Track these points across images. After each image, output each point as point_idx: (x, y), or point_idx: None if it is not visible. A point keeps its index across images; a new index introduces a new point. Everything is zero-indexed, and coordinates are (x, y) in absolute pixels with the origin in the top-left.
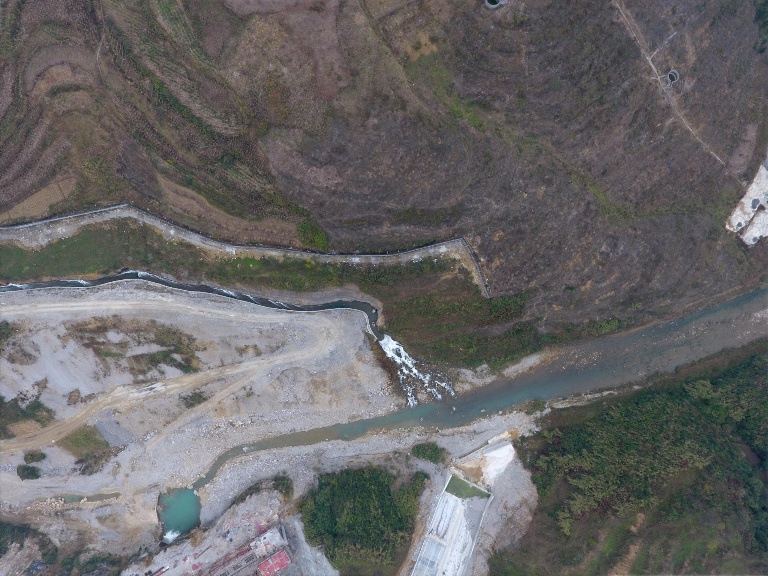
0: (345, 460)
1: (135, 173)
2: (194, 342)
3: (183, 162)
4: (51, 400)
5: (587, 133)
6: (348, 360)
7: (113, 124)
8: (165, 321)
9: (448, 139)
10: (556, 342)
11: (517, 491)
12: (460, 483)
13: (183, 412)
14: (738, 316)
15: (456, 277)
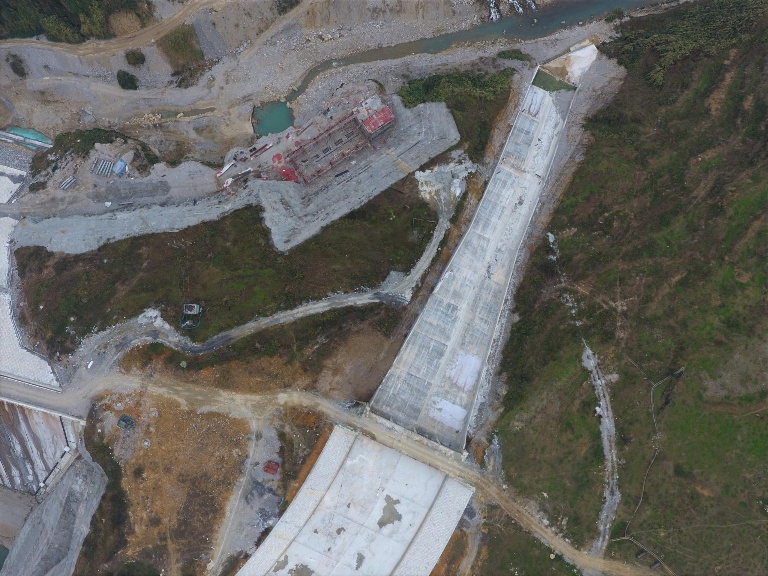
0: (433, 67)
1: None
2: None
3: None
4: None
5: None
6: None
7: None
8: None
9: None
10: None
11: (604, 76)
12: (547, 77)
13: (275, 20)
14: None
15: None
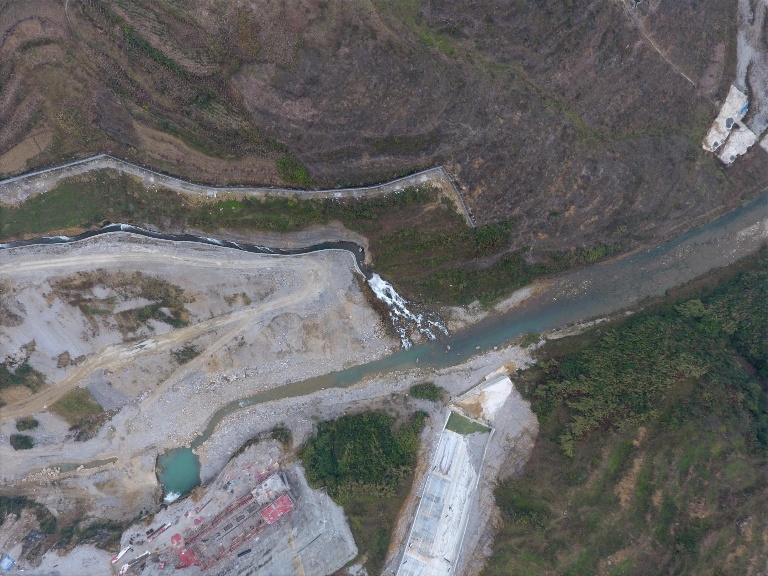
0: (343, 407)
1: (111, 122)
2: (182, 293)
3: (158, 106)
4: (40, 363)
5: (557, 57)
6: (338, 301)
7: (86, 74)
8: (151, 272)
9: (420, 65)
10: (545, 273)
11: (518, 422)
12: (460, 419)
13: (176, 369)
14: (723, 236)
15: (439, 207)
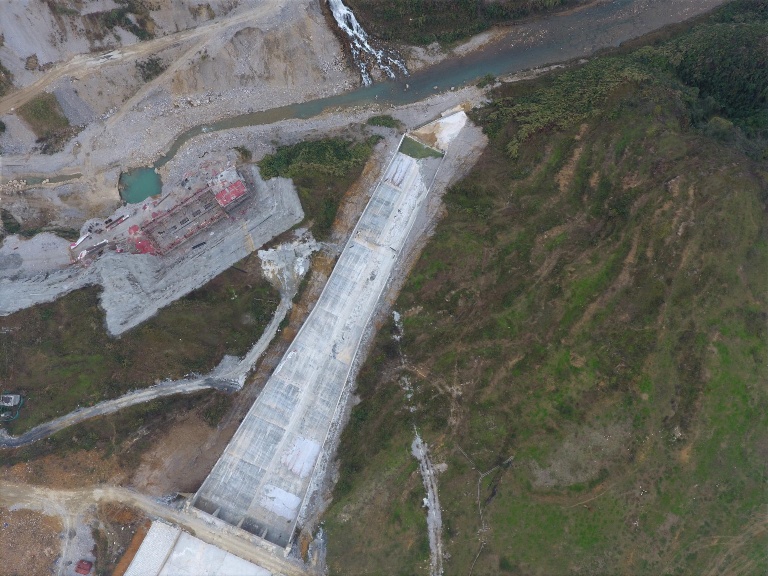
0: (302, 133)
1: None
2: None
3: None
4: (8, 59)
5: None
6: (299, 15)
7: None
8: None
9: None
10: (503, 18)
11: (469, 144)
12: (414, 144)
13: (141, 87)
14: None
15: None
